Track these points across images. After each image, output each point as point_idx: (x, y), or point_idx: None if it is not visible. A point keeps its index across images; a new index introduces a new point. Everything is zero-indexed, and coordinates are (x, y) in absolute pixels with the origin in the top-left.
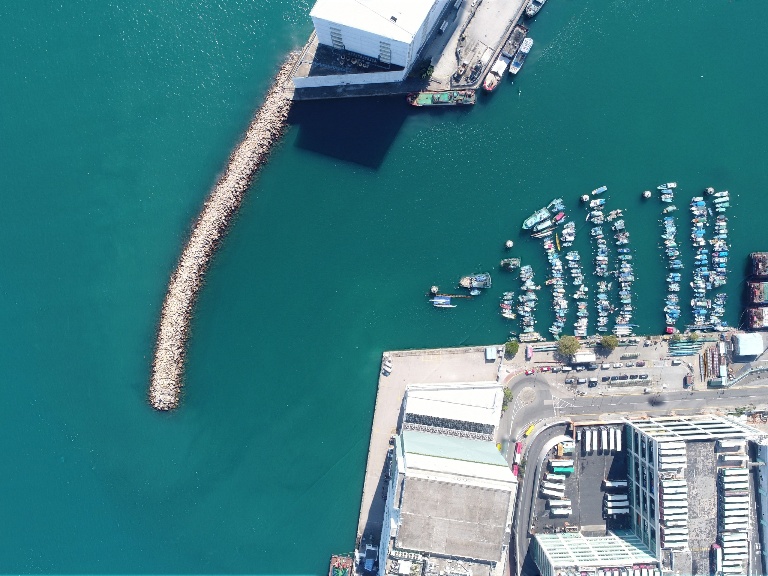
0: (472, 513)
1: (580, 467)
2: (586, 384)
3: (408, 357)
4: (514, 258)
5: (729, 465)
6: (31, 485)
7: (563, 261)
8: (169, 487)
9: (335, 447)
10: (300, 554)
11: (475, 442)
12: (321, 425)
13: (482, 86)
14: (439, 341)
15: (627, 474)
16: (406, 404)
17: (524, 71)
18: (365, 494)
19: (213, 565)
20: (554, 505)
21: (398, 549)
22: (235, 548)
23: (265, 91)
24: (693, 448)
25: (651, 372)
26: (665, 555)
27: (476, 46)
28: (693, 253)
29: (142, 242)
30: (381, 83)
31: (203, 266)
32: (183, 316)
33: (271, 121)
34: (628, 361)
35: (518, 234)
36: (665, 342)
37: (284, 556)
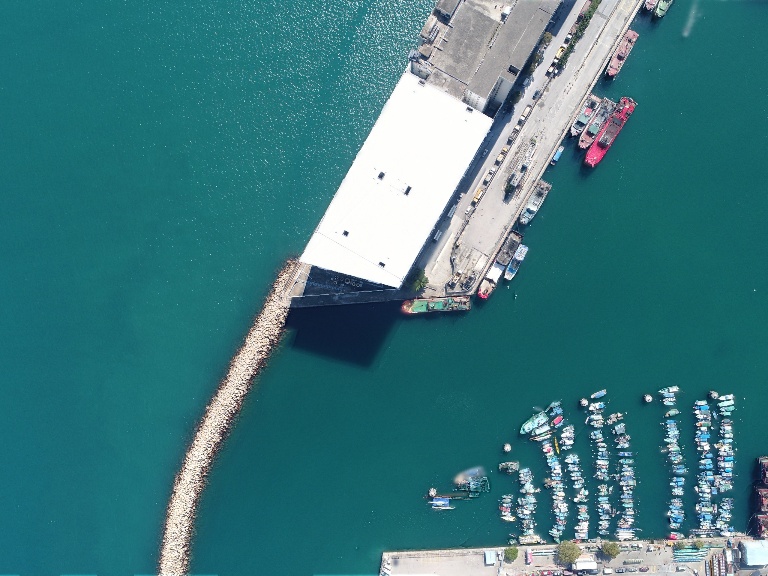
0: None
1: None
2: None
3: (407, 559)
4: (512, 462)
5: None
6: None
7: (562, 464)
8: None
9: None
10: None
11: None
12: None
13: (477, 294)
14: (438, 543)
15: None
16: None
17: (520, 275)
18: None
19: None
20: None
21: None
22: None
23: (263, 297)
24: None
25: None
26: None
27: (471, 253)
28: (697, 456)
29: (147, 445)
30: (376, 291)
31: (206, 467)
32: (187, 516)
33: (269, 329)
34: (631, 566)
35: (516, 436)
36: (669, 547)
37: None
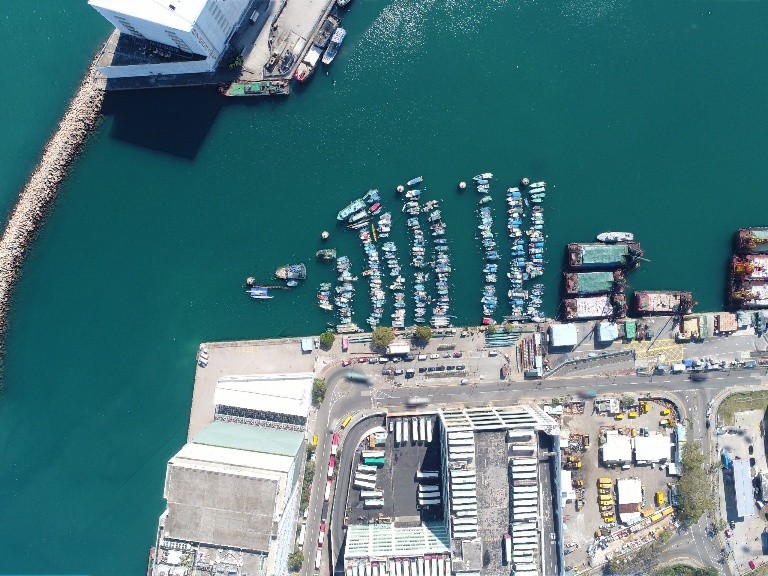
0: (239, 503)
1: (393, 458)
2: (403, 375)
3: (225, 348)
4: (330, 249)
5: (520, 455)
6: None
7: (380, 252)
8: None
9: (154, 439)
10: (120, 546)
11: (283, 433)
12: (140, 417)
13: (294, 76)
14: (256, 332)
15: (440, 465)
16: None
17: (339, 61)
18: None
19: (33, 557)
20: (367, 496)
21: (168, 539)
22: (56, 540)
23: (79, 81)
24: (484, 438)
25: (468, 363)
26: (456, 545)
27: (289, 36)
28: (510, 244)
29: None
30: (193, 73)
31: (19, 257)
32: None
33: (83, 111)
34: (445, 352)
35: (335, 225)
36: (482, 333)
37: (104, 548)
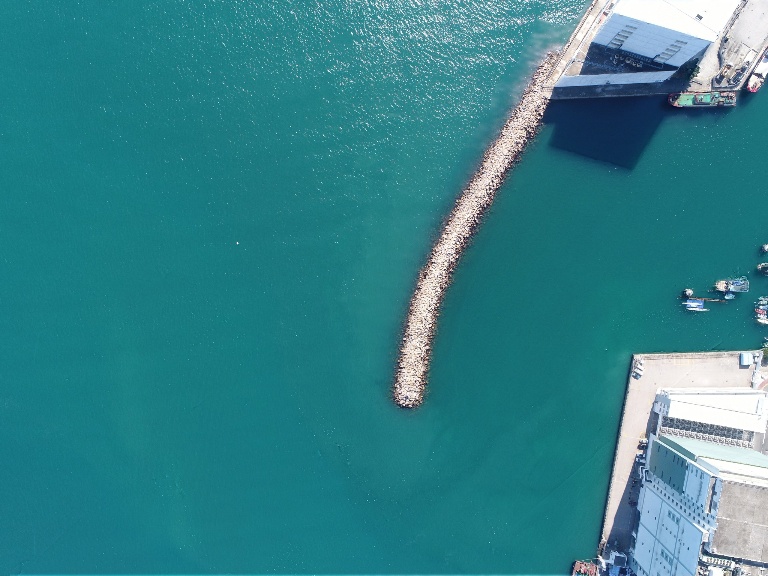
0: None
1: None
2: None
3: (660, 360)
4: None
5: None
6: (290, 478)
7: None
8: (411, 485)
9: (580, 450)
10: (541, 558)
11: (739, 449)
12: (566, 427)
13: (746, 88)
14: (691, 345)
15: None
16: (669, 408)
17: None
18: (611, 499)
19: (452, 566)
20: None
21: (709, 555)
22: (474, 550)
23: (520, 90)
24: None
25: None
26: None
27: (739, 48)
28: None
29: (393, 238)
30: (641, 83)
31: (453, 263)
32: (431, 313)
33: (528, 120)
34: None
35: None
36: None
37: (524, 560)
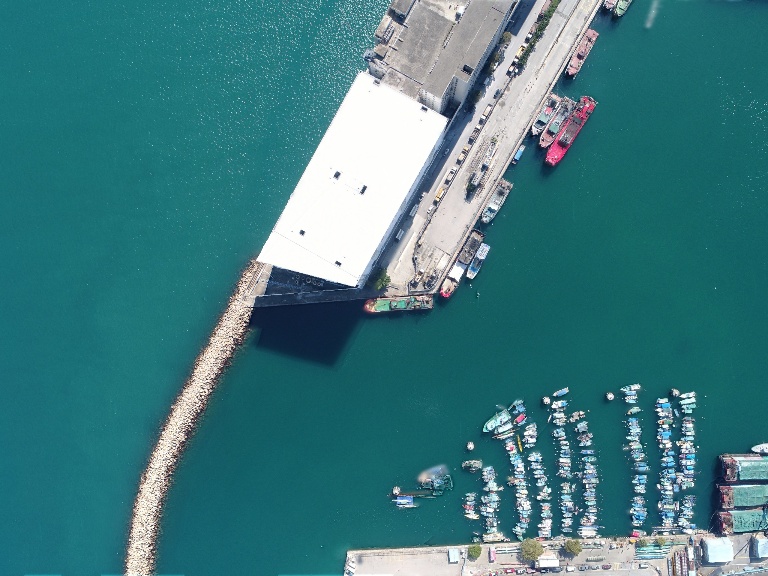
0: None
1: None
2: None
3: (371, 557)
4: (475, 460)
5: None
6: None
7: (525, 462)
8: None
9: None
10: None
11: None
12: None
13: (439, 292)
14: (402, 541)
15: None
16: None
17: (482, 274)
18: None
19: None
20: None
21: None
22: None
23: (228, 297)
24: None
25: (618, 575)
26: None
27: (433, 252)
28: (659, 454)
29: (113, 444)
30: (339, 290)
31: (171, 467)
32: (153, 515)
33: (233, 328)
34: (594, 564)
35: (480, 435)
36: (632, 545)
37: None
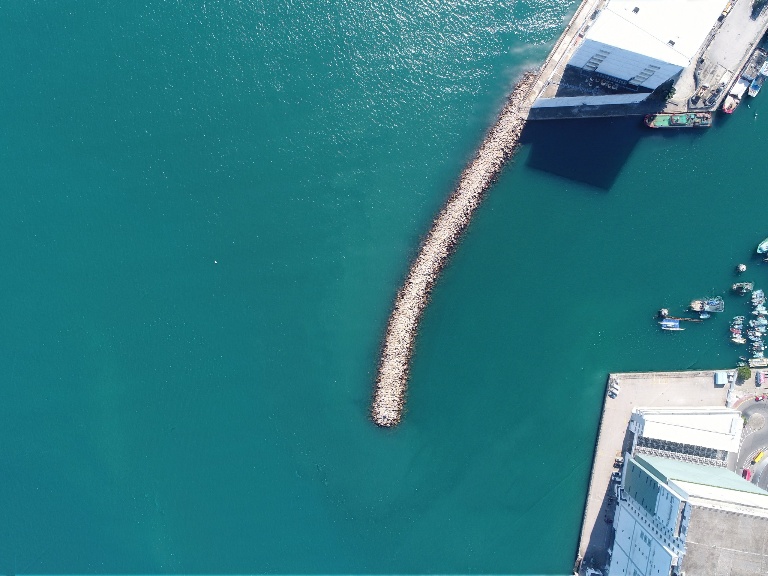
0: (758, 544)
1: None
2: None
3: (635, 380)
4: (747, 282)
5: None
6: (267, 499)
7: None
8: (389, 504)
9: (557, 468)
10: (518, 575)
11: (713, 468)
12: (542, 446)
13: (721, 109)
14: (666, 364)
15: None
16: (643, 428)
17: (761, 94)
18: (587, 517)
19: None
20: None
21: None
22: (452, 567)
23: (498, 110)
24: None
25: None
26: None
27: (715, 69)
28: None
29: (371, 258)
30: (617, 104)
31: (430, 283)
32: (409, 333)
33: (505, 140)
34: None
35: (750, 258)
36: None
37: None
